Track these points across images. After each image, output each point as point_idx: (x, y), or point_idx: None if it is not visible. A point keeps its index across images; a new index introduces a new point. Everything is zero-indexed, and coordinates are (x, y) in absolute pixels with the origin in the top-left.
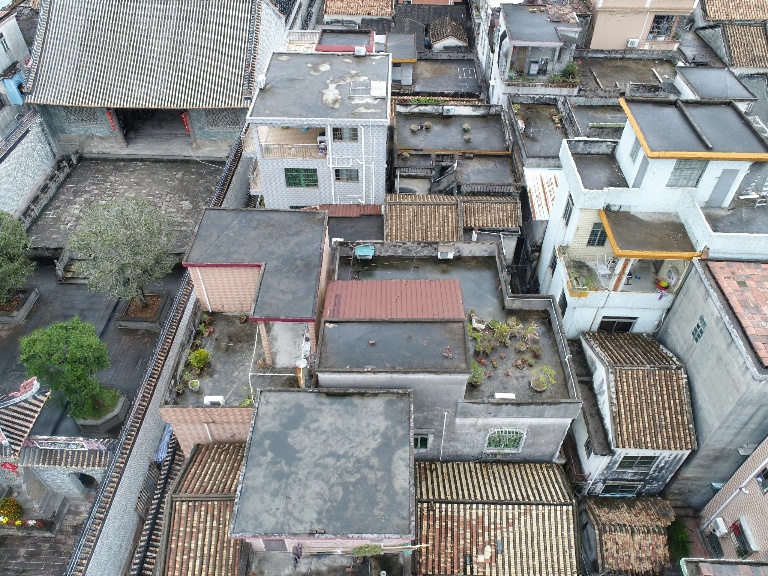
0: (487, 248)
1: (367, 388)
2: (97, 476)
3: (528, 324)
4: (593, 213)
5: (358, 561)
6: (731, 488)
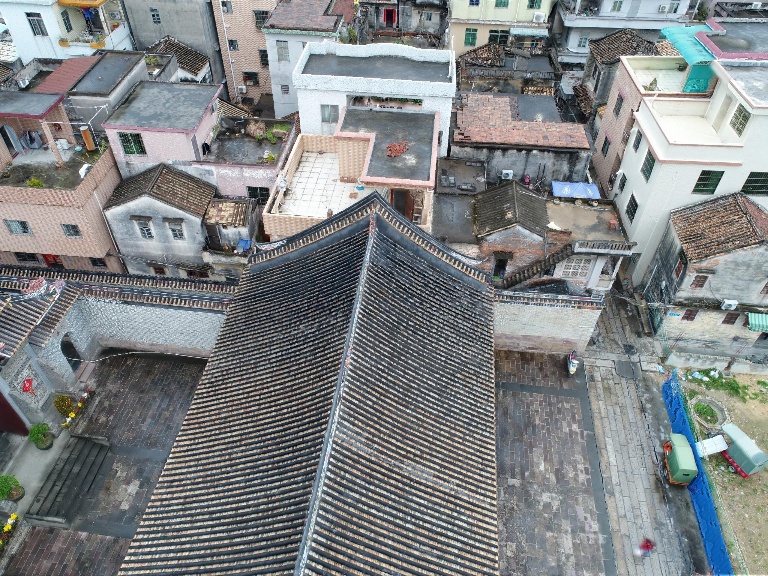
0: (34, 67)
1: (128, 91)
2: (73, 328)
3: None
4: (56, 6)
5: (218, 140)
6: (228, 71)
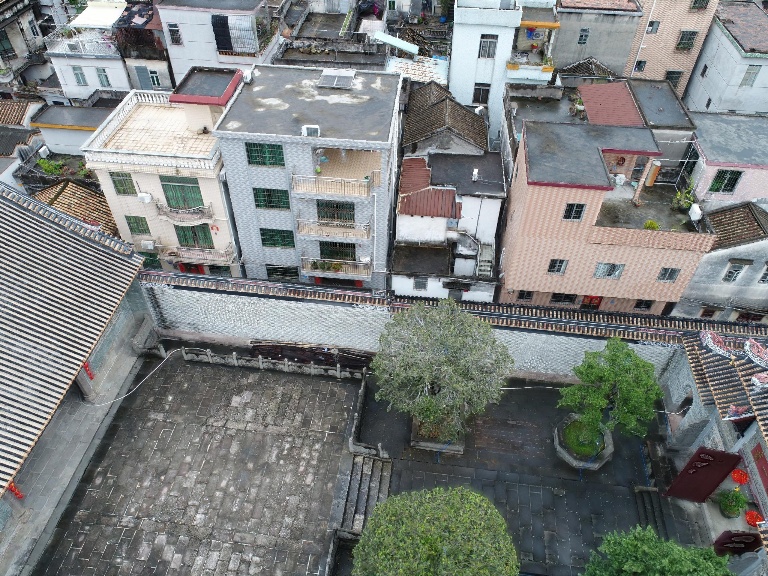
0: None
1: None
2: None
3: (571, 94)
4: None
5: None
6: None
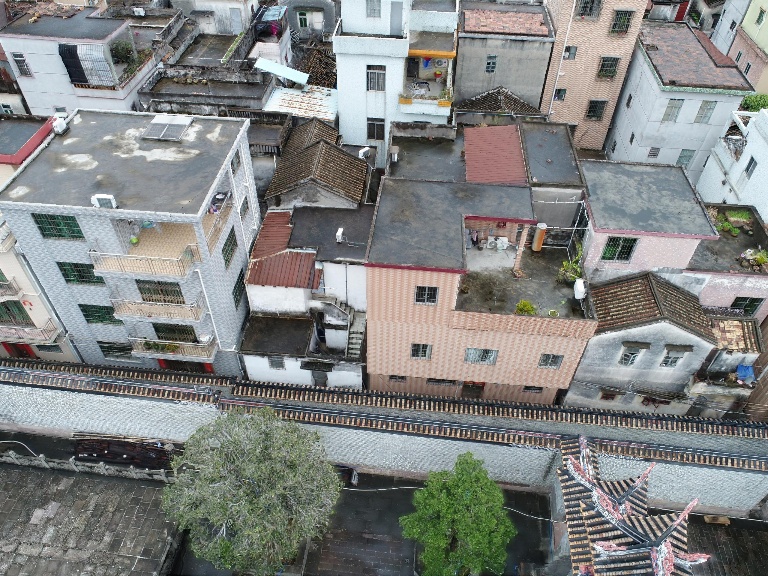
0: None
1: None
2: None
3: None
4: None
5: None
6: None
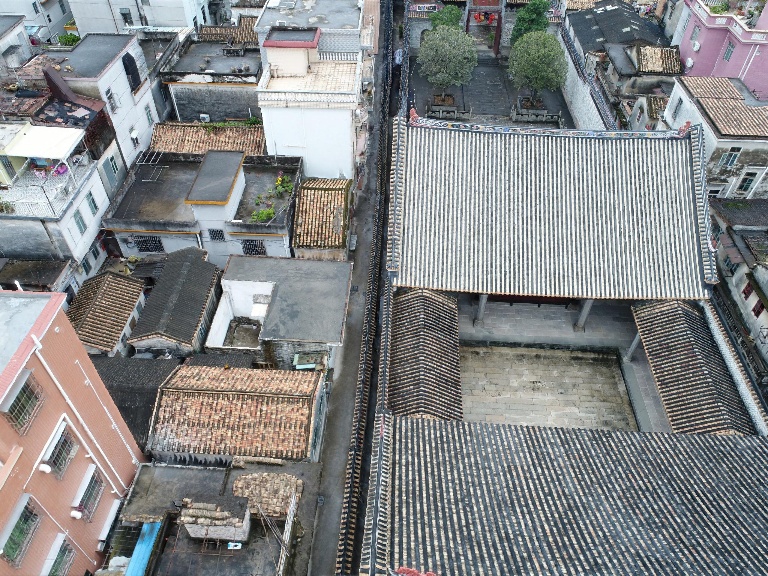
0: None
1: None
2: None
3: None
4: None
5: None
6: None
